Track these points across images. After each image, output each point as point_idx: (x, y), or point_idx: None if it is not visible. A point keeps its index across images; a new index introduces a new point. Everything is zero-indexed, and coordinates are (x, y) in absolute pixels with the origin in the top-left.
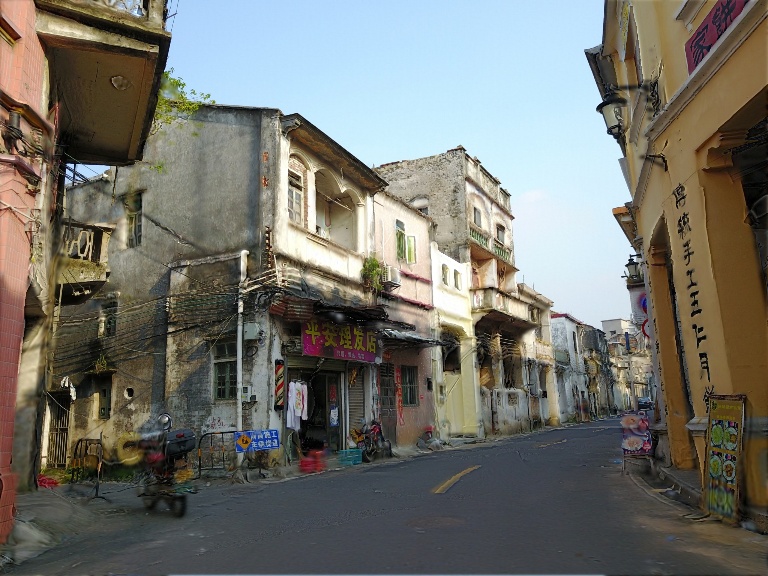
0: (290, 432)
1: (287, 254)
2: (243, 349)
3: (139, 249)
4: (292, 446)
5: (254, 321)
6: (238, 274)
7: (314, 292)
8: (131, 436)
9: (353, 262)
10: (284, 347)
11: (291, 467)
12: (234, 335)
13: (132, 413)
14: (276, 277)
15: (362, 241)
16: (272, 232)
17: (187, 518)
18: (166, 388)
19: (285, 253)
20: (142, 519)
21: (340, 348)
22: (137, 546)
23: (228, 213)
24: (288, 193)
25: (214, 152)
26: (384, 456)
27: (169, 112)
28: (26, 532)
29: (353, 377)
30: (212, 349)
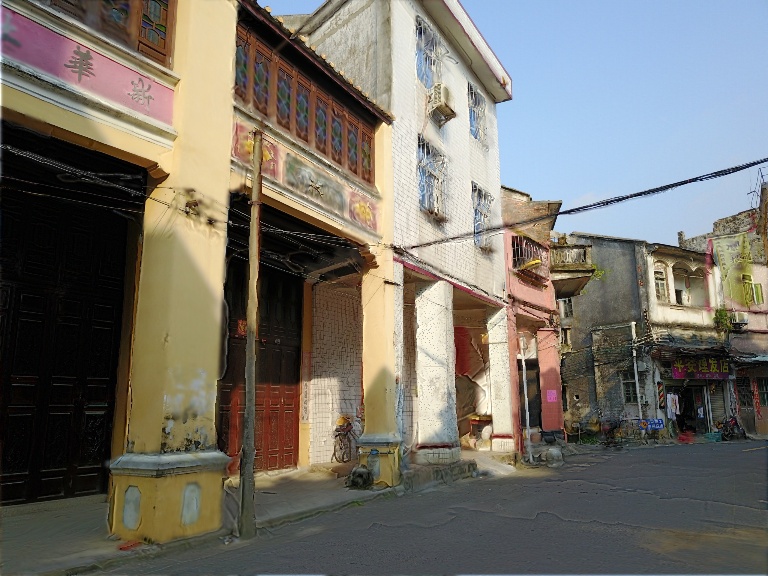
0: (670, 421)
1: (658, 322)
2: (638, 376)
3: (572, 319)
4: (673, 429)
5: (643, 361)
6: (631, 335)
7: (678, 341)
8: (581, 420)
9: (706, 315)
10: (662, 375)
11: (673, 440)
12: (632, 368)
13: (579, 408)
14: (653, 337)
15: (713, 298)
16: (648, 312)
17: (622, 452)
18: (597, 395)
19: (657, 322)
20: (605, 451)
21: (699, 372)
22: (609, 454)
23: (621, 300)
24: (655, 285)
25: (609, 265)
26: (739, 438)
27: (592, 279)
28: (572, 448)
29: (712, 389)
30: (621, 375)
